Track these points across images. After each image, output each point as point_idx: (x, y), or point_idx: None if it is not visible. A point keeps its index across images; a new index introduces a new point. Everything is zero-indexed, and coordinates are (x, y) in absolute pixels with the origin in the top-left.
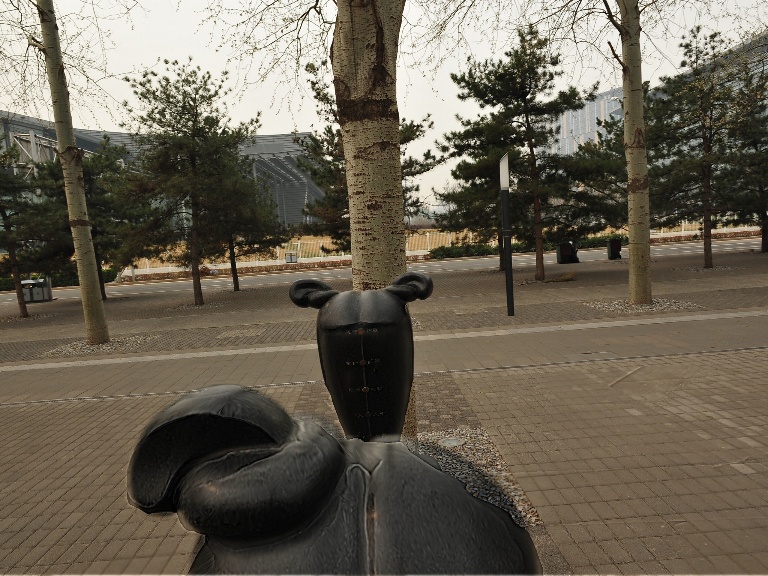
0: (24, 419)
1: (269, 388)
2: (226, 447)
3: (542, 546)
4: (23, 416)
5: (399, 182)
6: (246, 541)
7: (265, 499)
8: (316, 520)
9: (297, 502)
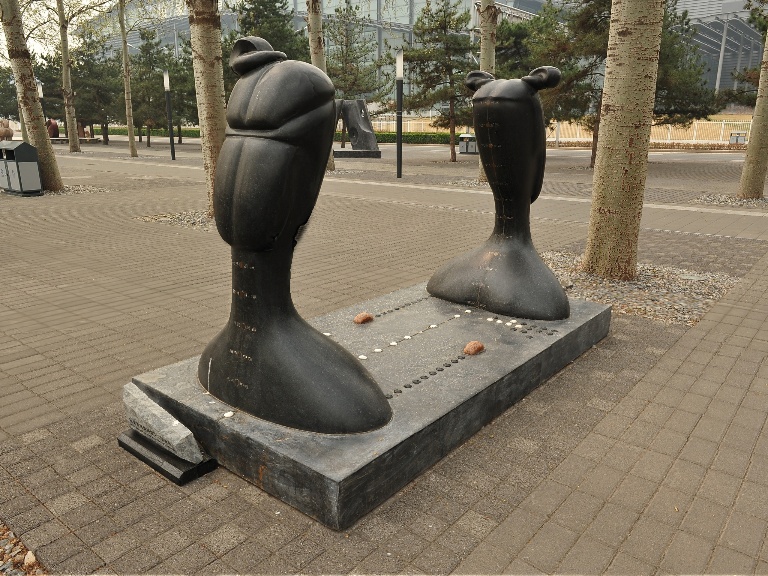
0: (405, 211)
1: (583, 224)
2: (247, 50)
3: (669, 332)
4: (406, 209)
5: (657, 9)
6: (242, 72)
7: (246, 60)
8: (257, 68)
9: (249, 60)
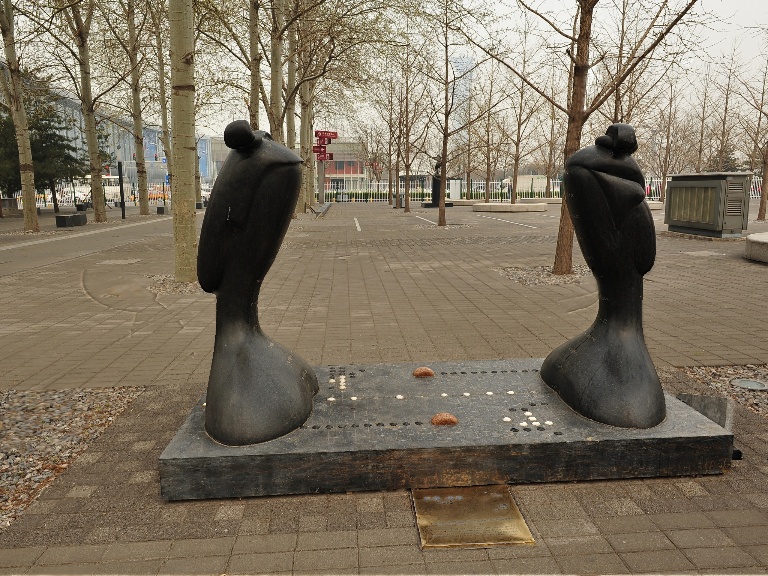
0: None
1: None
2: None
3: (182, 387)
4: None
5: None
6: None
7: None
8: None
9: None
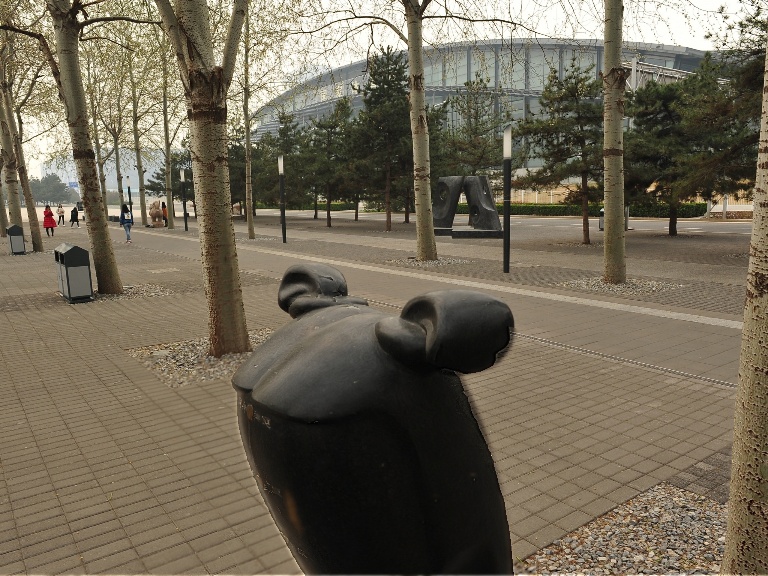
0: None
1: None
2: None
3: None
4: None
5: None
6: None
7: None
8: None
9: None
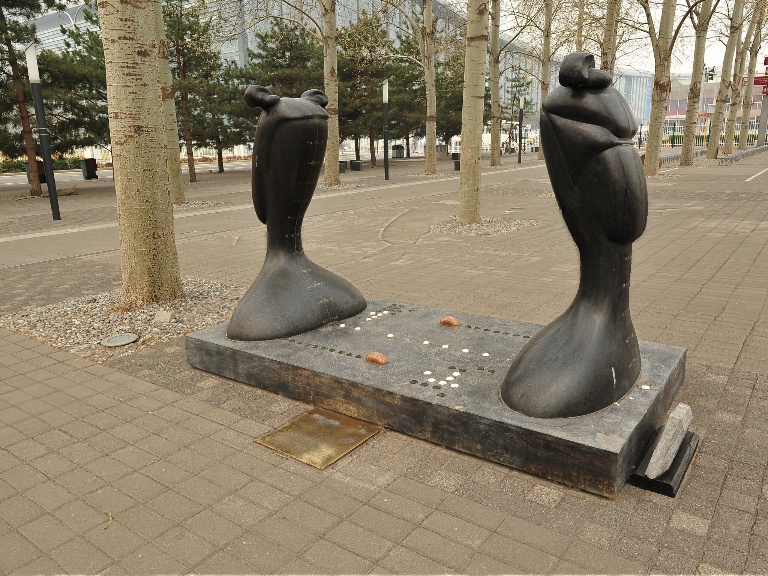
0: None
1: None
2: None
3: None
4: None
5: None
6: (603, 86)
7: None
8: None
9: None
